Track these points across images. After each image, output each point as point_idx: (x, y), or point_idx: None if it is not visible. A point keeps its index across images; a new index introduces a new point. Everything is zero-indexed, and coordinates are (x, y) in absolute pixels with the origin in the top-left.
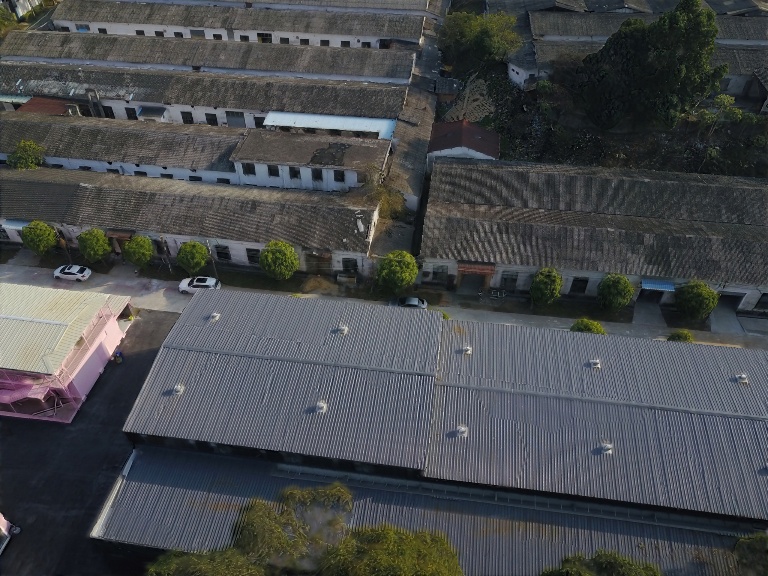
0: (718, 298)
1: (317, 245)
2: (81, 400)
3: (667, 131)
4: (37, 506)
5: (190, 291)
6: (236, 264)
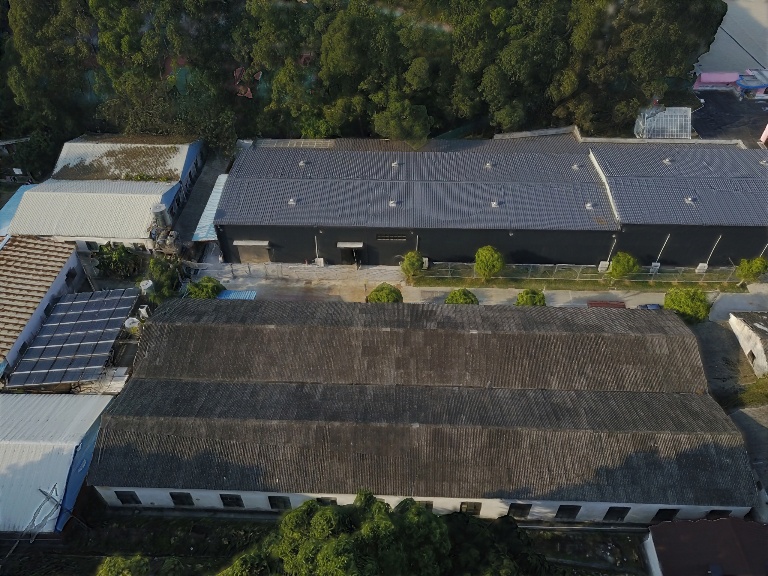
0: (367, 298)
1: None
2: None
3: None
4: None
5: None
6: None
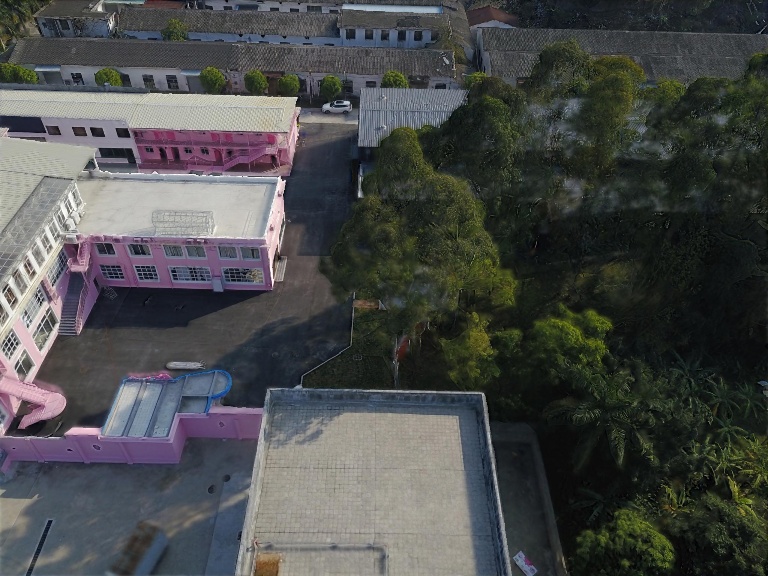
0: None
1: (419, 74)
2: (291, 164)
3: (631, 9)
4: (294, 211)
5: (332, 111)
6: (356, 96)
